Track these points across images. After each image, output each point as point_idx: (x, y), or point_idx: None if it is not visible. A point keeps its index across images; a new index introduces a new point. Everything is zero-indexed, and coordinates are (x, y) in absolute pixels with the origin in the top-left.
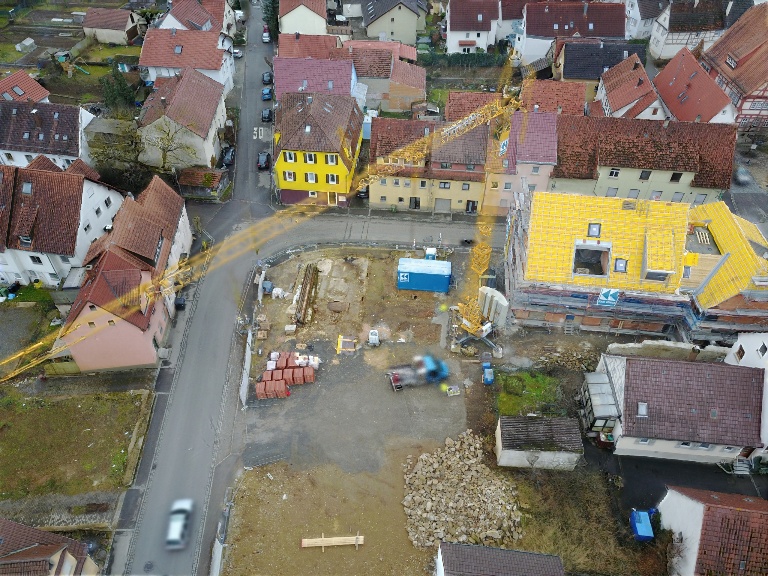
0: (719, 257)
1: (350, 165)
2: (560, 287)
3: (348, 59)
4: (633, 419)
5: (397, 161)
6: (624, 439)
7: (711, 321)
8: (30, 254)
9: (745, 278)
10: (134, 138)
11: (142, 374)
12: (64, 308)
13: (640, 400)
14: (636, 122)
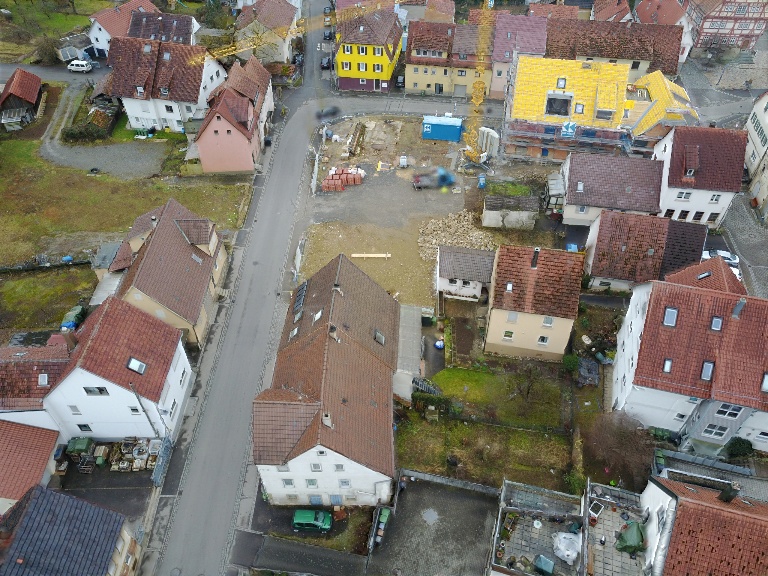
0: (649, 103)
1: (391, 58)
2: (535, 122)
3: None
4: (574, 193)
5: (426, 53)
6: (568, 208)
7: (641, 147)
8: (166, 104)
9: (663, 112)
10: (232, 39)
11: (244, 177)
12: (191, 136)
13: (579, 181)
14: (607, 23)
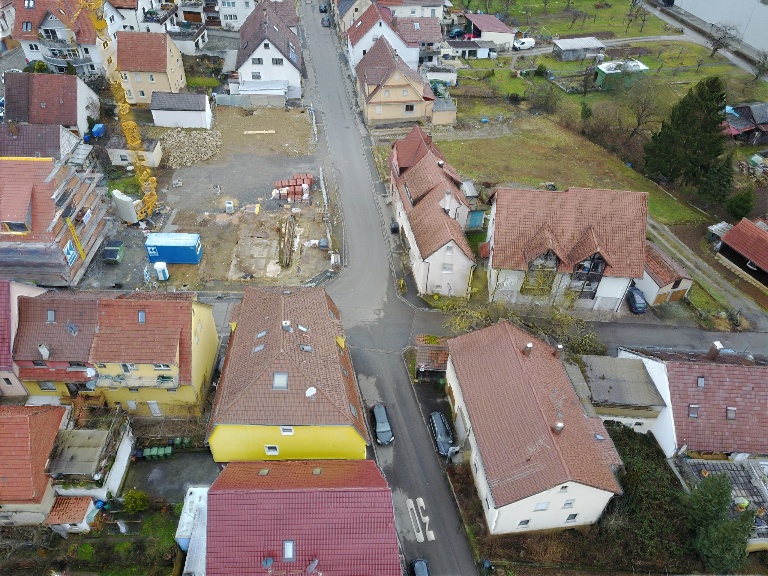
0: None
1: None
2: None
3: None
4: None
5: None
6: None
7: None
8: None
9: None
10: None
11: None
12: None
13: None
14: None
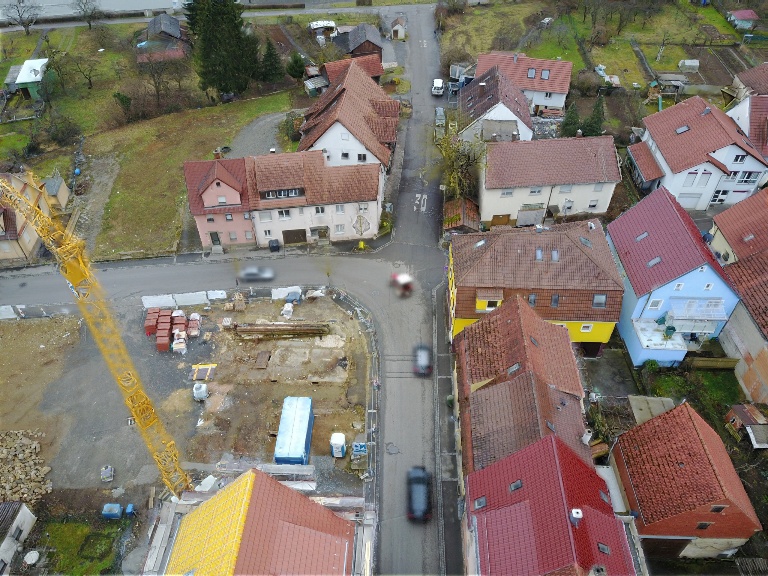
0: None
1: (471, 315)
2: (151, 565)
3: (766, 274)
4: None
5: None
6: None
7: None
8: None
9: None
10: None
11: (197, 244)
12: None
13: None
14: None
